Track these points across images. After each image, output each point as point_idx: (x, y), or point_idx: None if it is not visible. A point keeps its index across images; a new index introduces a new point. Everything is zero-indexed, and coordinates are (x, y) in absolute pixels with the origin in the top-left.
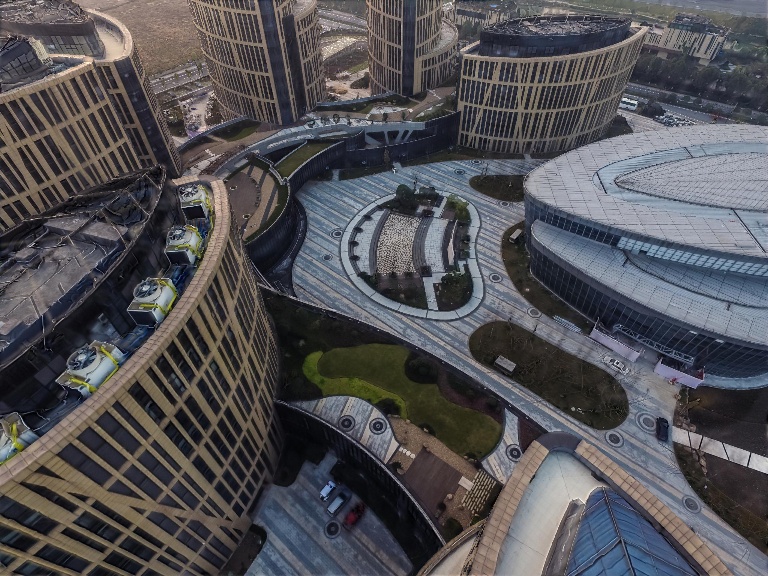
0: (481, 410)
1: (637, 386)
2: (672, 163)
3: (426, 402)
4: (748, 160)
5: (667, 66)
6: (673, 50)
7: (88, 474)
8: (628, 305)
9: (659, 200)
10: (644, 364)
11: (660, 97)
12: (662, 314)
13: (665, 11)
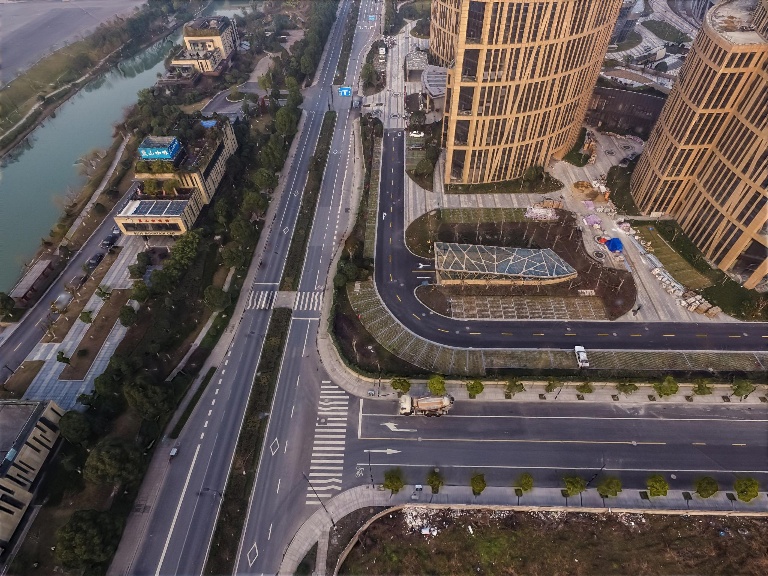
0: None
1: None
2: None
3: None
4: None
5: (304, 40)
6: (231, 52)
7: None
8: None
9: None
10: None
11: None
12: None
13: (33, 84)
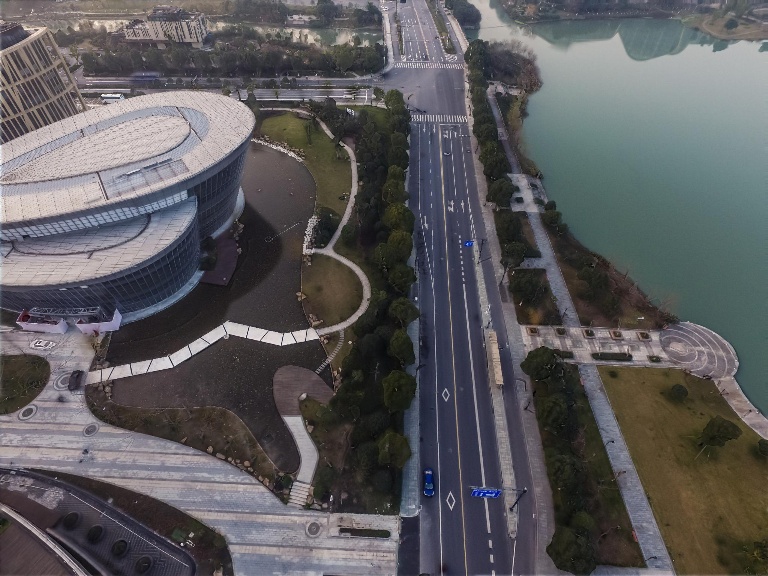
0: None
1: (62, 353)
2: (61, 147)
3: None
4: (129, 126)
5: None
6: (166, 40)
7: None
8: (9, 290)
9: (34, 185)
10: (74, 331)
11: (149, 85)
12: (26, 286)
13: None
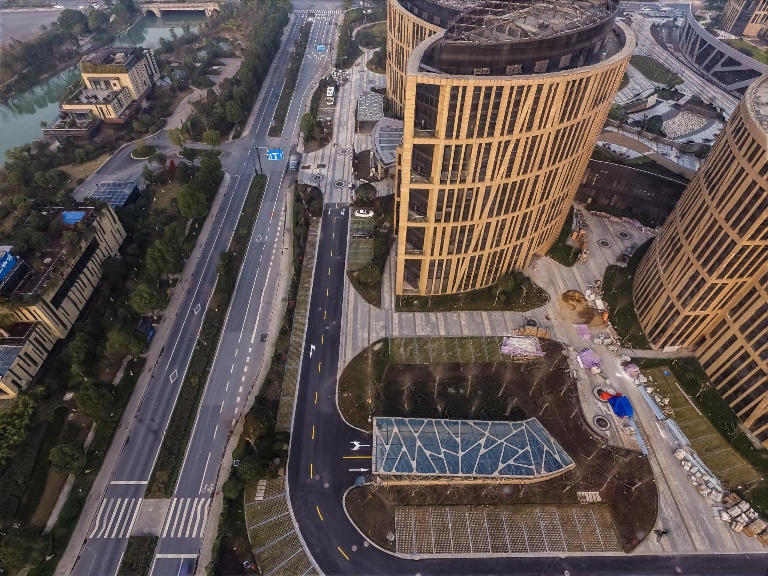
0: None
1: None
2: None
3: None
4: None
5: (236, 77)
6: (146, 90)
7: None
8: None
9: None
10: None
11: None
12: None
13: None
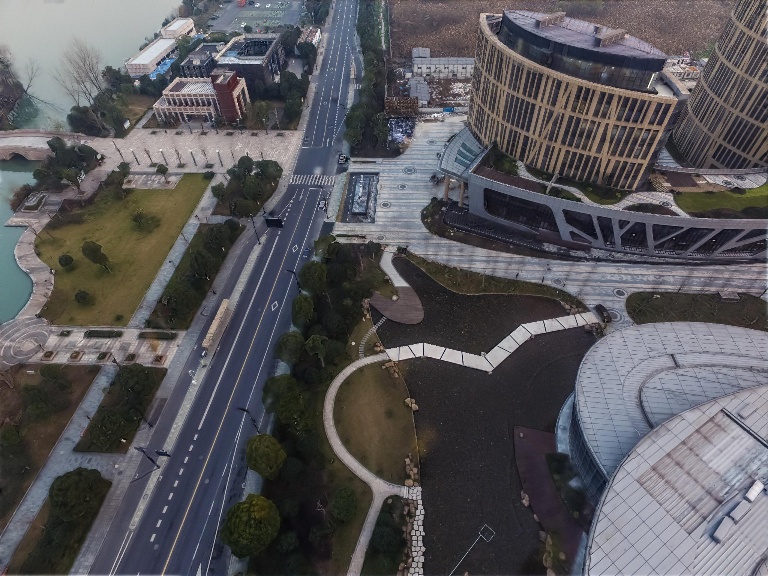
0: (704, 212)
1: None
2: None
3: (729, 202)
4: None
5: None
6: None
7: (767, 24)
8: None
9: None
10: None
11: None
12: None
13: None
